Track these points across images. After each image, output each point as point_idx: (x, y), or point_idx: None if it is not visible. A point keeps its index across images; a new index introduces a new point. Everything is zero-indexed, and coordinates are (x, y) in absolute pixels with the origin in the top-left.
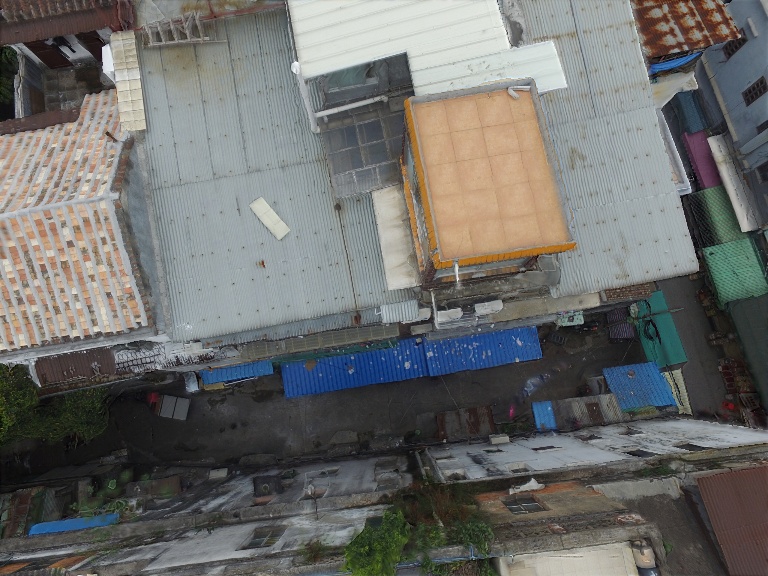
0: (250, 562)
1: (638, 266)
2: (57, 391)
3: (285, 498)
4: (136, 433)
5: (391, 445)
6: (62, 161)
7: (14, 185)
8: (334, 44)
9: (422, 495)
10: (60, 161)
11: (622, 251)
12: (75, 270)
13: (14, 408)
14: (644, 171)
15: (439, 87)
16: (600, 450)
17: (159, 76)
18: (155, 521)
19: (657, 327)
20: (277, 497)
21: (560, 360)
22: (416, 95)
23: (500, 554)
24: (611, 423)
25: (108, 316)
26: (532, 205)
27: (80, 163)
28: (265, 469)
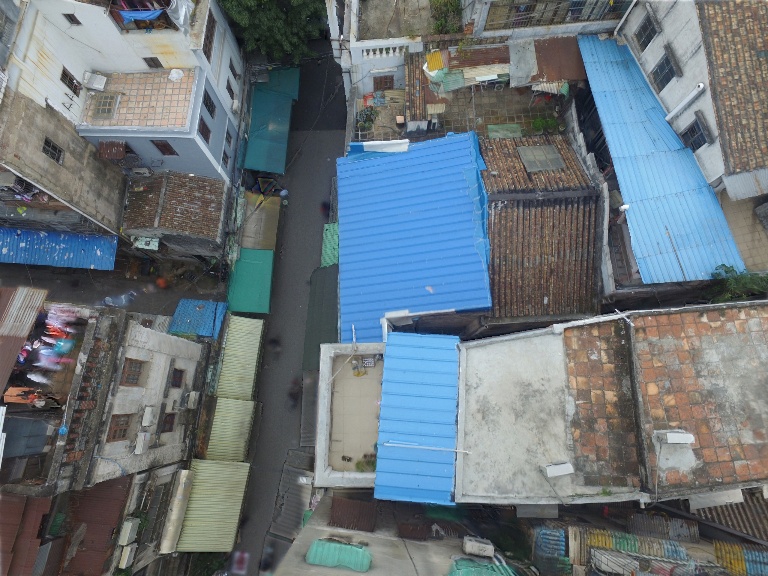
0: None
1: None
2: None
3: None
4: None
5: None
6: None
7: None
8: None
9: None
10: None
11: None
12: None
13: None
14: None
15: None
16: None
17: None
18: None
19: (253, 279)
20: None
21: (189, 296)
22: None
23: None
24: None
25: None
26: None
27: None
28: None
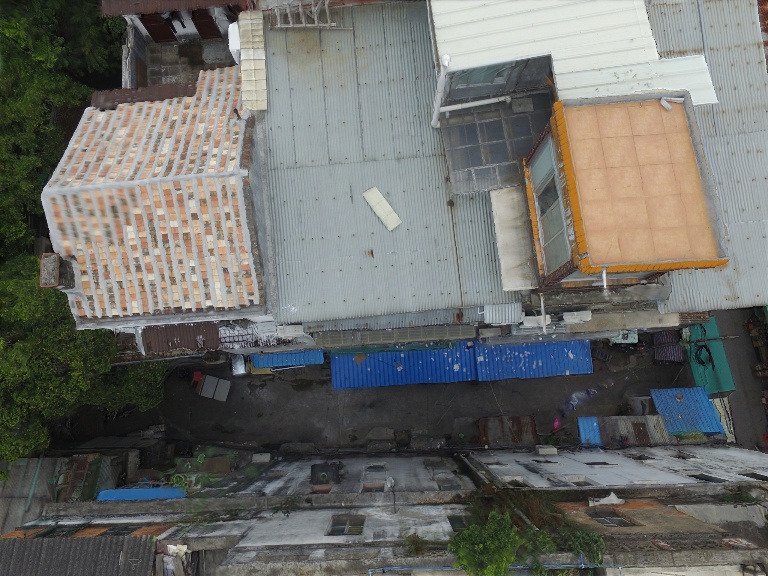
0: (348, 548)
1: (749, 289)
2: (120, 361)
3: (345, 488)
4: (174, 410)
5: (432, 446)
6: (185, 134)
7: (140, 154)
8: (476, 40)
9: (501, 498)
10: (183, 134)
11: (734, 272)
12: (196, 243)
13: (90, 374)
14: (761, 194)
15: (584, 92)
16: (660, 471)
17: (283, 58)
18: (227, 499)
19: (707, 353)
20: (336, 487)
21: (602, 377)
22: (560, 98)
23: (610, 565)
24: (659, 445)
25: (222, 291)
26: (683, 218)
27: (204, 137)
28: (308, 458)
